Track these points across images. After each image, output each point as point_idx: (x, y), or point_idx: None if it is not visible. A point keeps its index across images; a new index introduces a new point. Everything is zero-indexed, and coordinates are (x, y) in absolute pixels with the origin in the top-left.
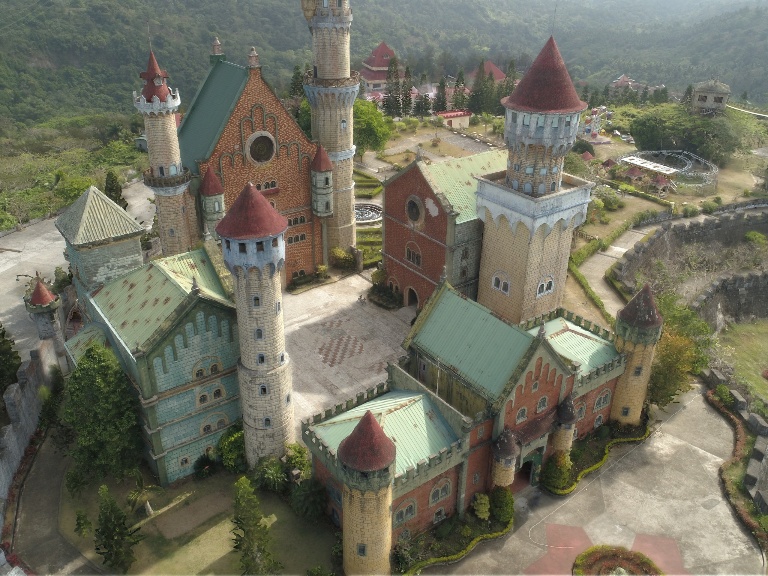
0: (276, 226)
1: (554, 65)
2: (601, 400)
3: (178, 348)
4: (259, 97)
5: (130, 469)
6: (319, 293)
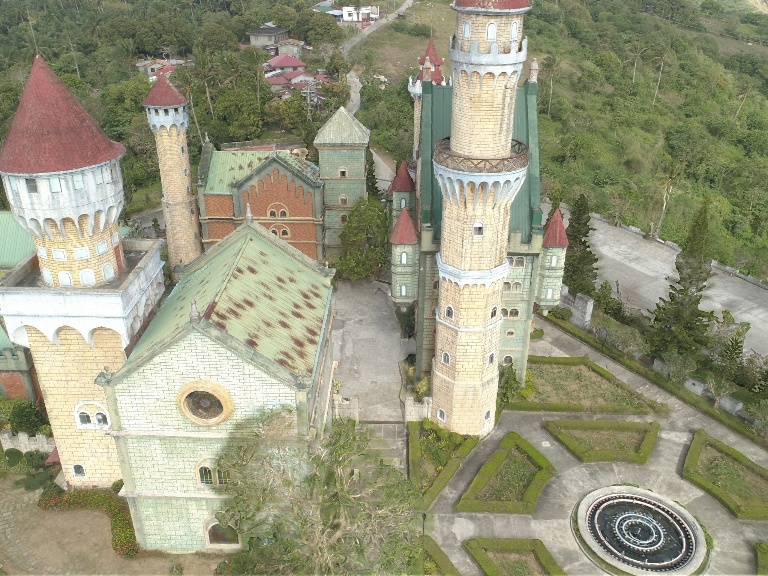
0: None
1: None
2: None
3: None
4: None
5: None
6: (387, 377)
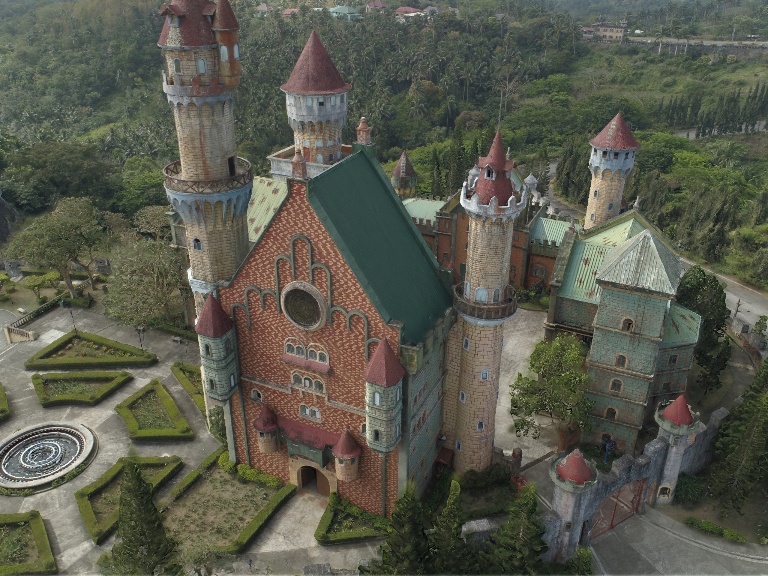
0: None
1: None
2: None
3: None
4: None
5: None
6: None
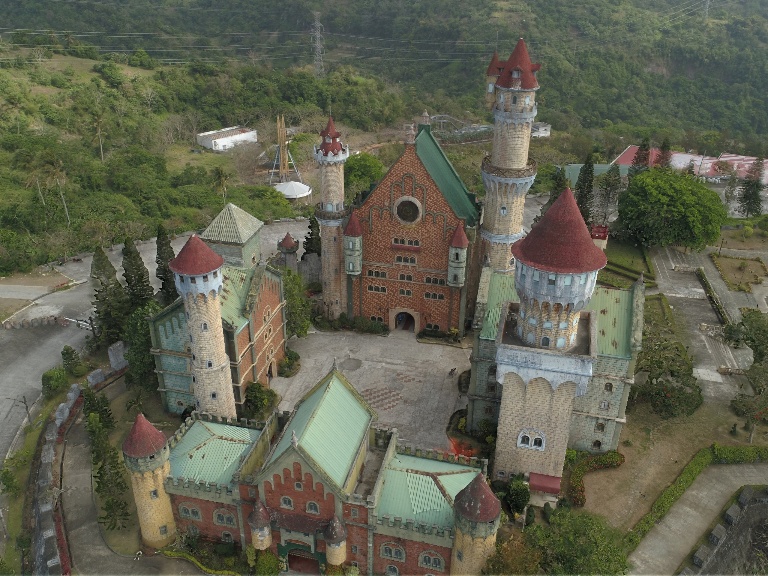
0: (195, 269)
1: (557, 217)
2: (431, 559)
3: (175, 326)
4: (412, 168)
5: (154, 389)
6: (436, 350)
